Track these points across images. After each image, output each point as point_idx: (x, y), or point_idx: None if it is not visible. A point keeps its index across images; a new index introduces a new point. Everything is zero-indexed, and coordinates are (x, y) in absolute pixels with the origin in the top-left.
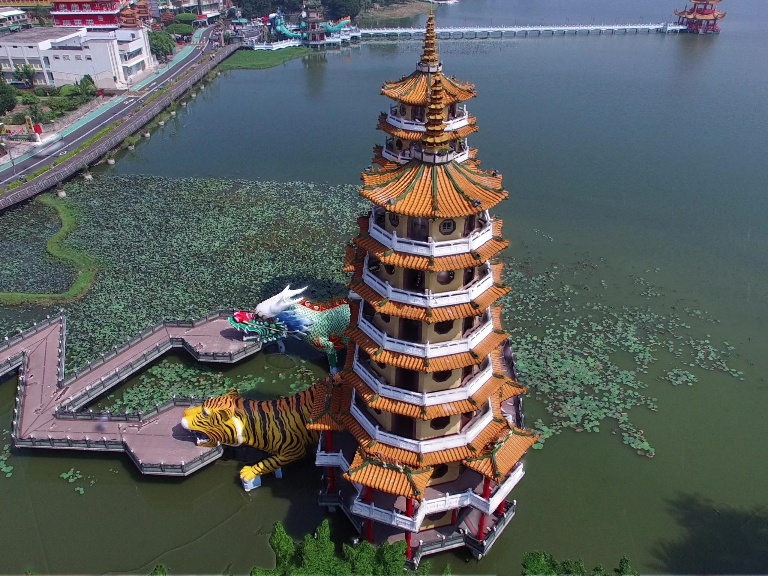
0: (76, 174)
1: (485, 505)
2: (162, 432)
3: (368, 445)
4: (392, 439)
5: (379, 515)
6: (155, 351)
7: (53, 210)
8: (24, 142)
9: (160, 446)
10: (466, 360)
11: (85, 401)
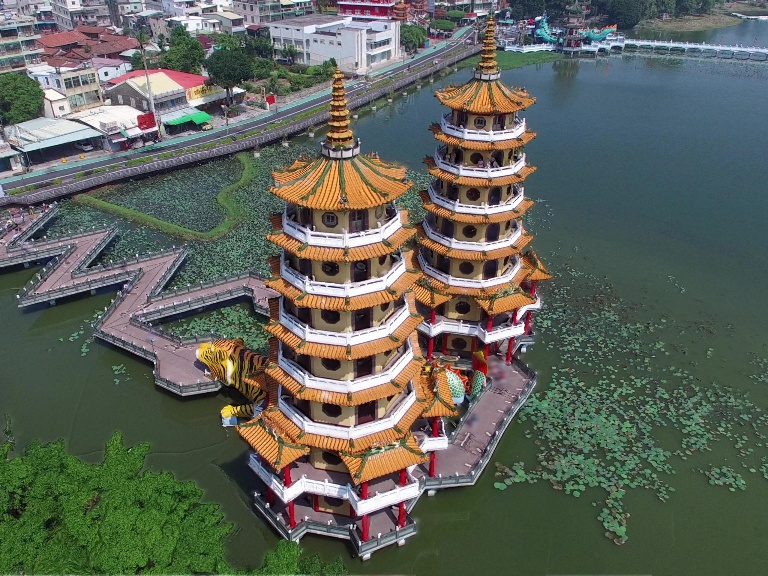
0: (278, 140)
1: (356, 504)
2: (189, 357)
3: (270, 409)
4: (288, 410)
5: (264, 475)
6: (228, 293)
7: (243, 166)
8: (257, 108)
9: (180, 367)
10: (340, 353)
11: (157, 317)
